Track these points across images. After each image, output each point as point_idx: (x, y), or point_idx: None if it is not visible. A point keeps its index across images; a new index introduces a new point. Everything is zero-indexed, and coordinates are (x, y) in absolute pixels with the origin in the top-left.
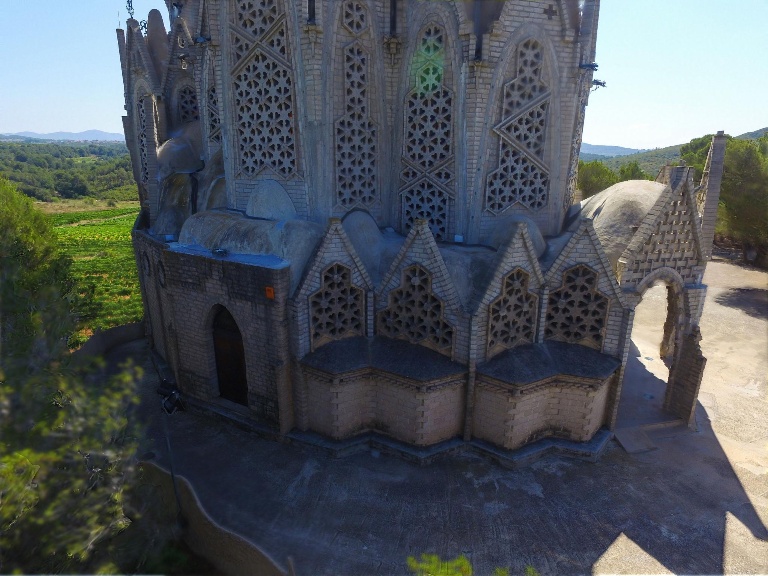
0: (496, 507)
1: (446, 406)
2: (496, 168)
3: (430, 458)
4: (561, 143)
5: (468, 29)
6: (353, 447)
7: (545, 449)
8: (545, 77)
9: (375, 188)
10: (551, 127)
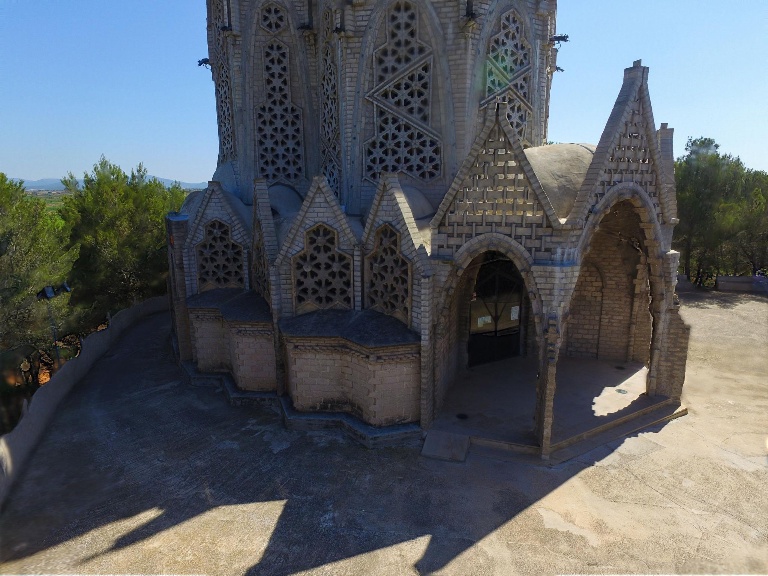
0: (229, 445)
1: (263, 356)
2: (372, 136)
3: (240, 400)
4: (454, 106)
5: (335, 5)
6: (206, 379)
7: (331, 420)
8: (425, 37)
9: (301, 166)
10: (438, 89)
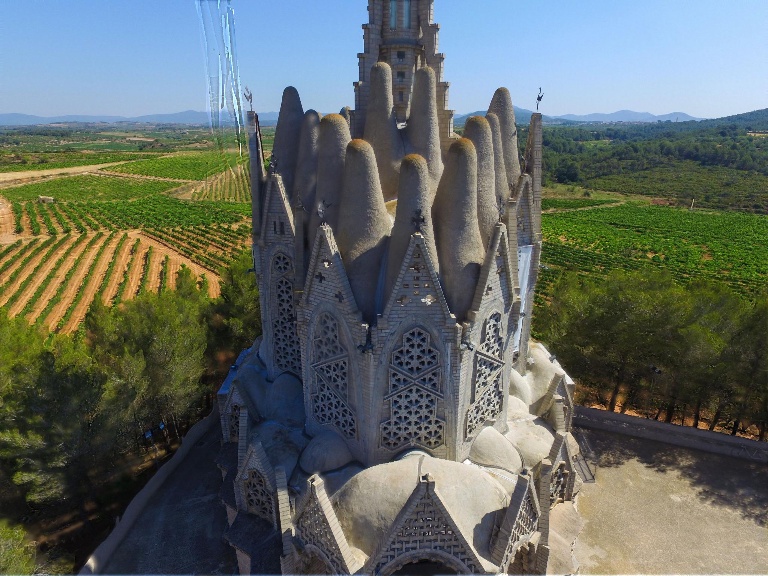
0: None
1: None
2: (316, 392)
3: None
4: (363, 396)
5: None
6: None
7: None
8: (344, 342)
9: None
10: (353, 380)
